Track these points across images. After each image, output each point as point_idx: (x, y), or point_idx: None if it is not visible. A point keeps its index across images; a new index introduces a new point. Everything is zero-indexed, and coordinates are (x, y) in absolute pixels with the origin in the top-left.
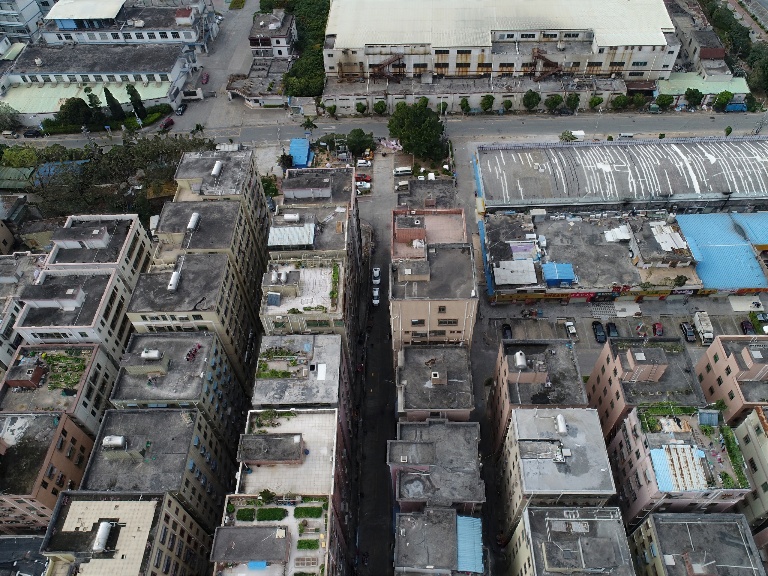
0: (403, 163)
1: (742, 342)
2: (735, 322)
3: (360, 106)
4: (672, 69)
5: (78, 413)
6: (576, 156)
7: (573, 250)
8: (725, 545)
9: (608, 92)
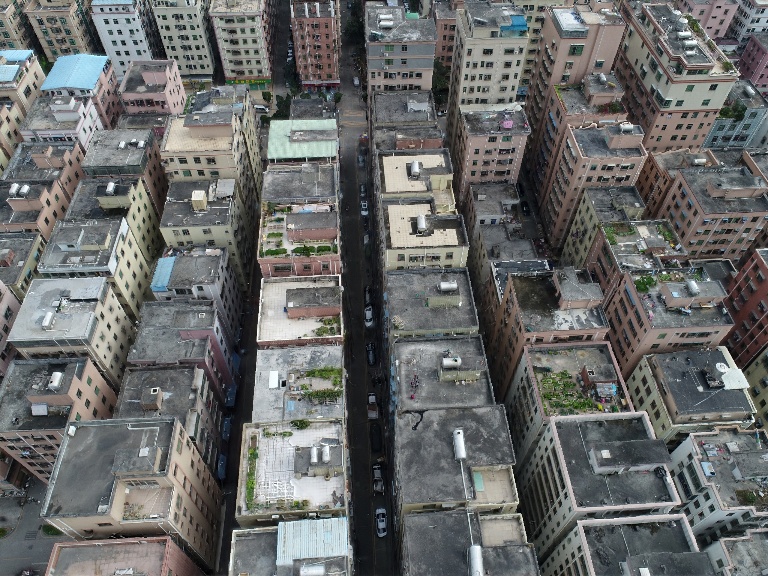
0: None
1: None
2: None
3: None
4: None
5: (524, 356)
6: None
7: None
8: None
9: None
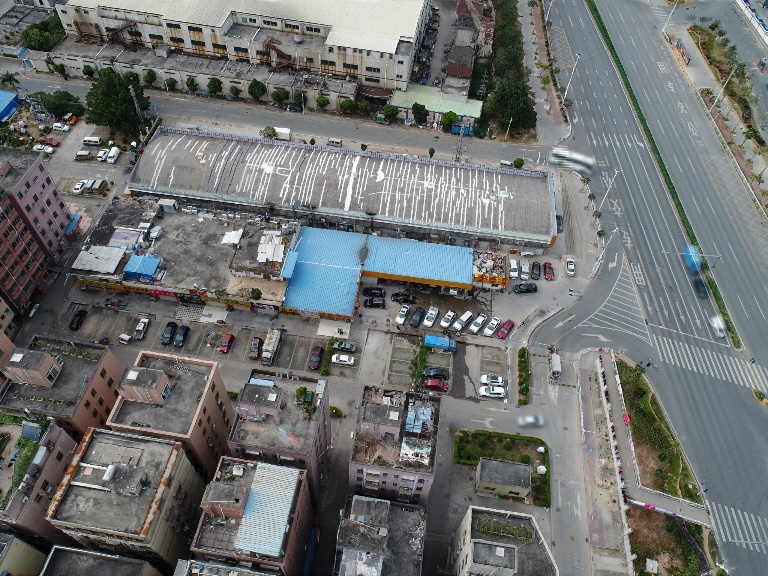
0: (101, 133)
1: (169, 361)
2: (312, 346)
3: (84, 69)
4: (431, 82)
5: None
6: (250, 152)
7: (182, 246)
8: None
9: (335, 94)
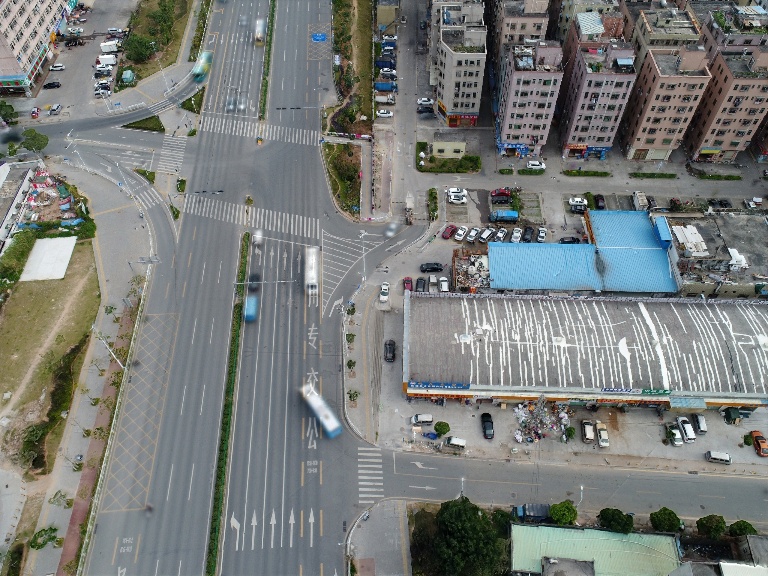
0: None
1: None
2: None
3: None
4: None
5: None
6: None
7: None
8: None
9: None
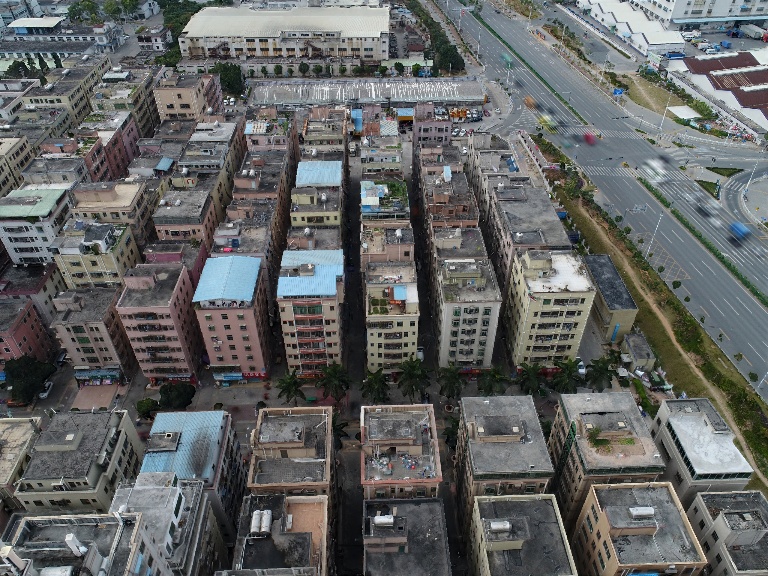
0: None
1: None
2: None
3: (199, 70)
4: None
5: None
6: None
7: None
8: (275, 159)
9: (349, 64)
